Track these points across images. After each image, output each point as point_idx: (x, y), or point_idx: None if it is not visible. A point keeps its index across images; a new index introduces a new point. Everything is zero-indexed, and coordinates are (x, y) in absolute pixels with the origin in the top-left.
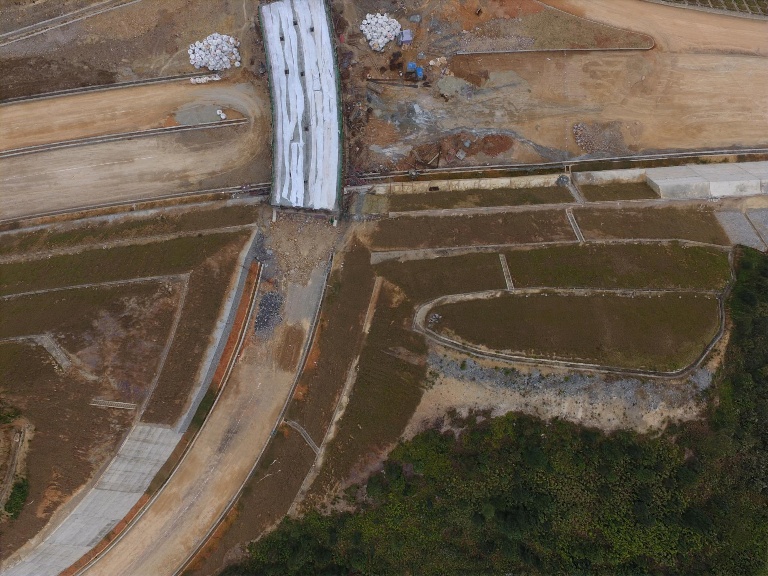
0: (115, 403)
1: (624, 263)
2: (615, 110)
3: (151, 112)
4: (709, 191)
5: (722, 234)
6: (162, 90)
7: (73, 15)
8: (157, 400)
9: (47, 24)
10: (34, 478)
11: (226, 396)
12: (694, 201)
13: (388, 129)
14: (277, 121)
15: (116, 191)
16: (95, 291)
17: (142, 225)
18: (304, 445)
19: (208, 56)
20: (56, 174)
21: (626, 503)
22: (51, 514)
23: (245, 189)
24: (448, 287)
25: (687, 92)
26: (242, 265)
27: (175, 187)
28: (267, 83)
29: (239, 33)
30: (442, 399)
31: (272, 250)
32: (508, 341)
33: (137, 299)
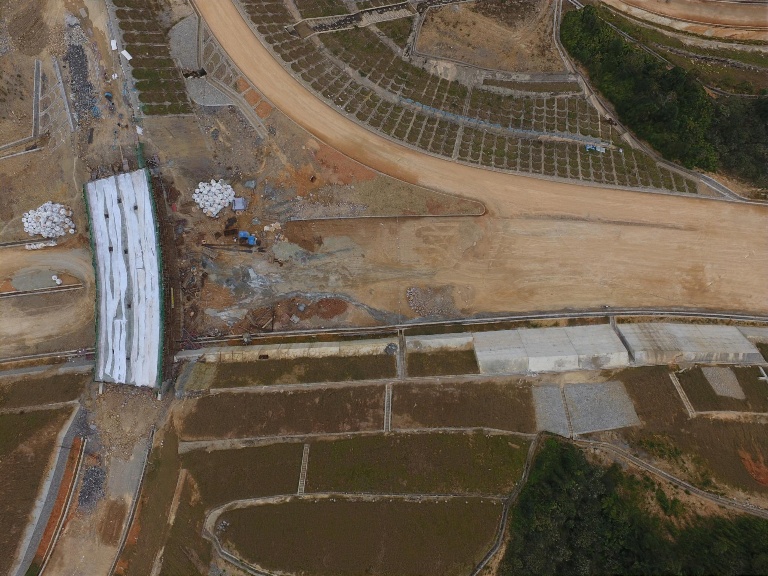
0: None
1: (420, 460)
2: (448, 274)
3: None
4: (528, 366)
5: (531, 418)
6: None
7: None
8: None
9: None
10: None
11: (51, 568)
12: (513, 376)
13: (223, 293)
14: (101, 298)
15: None
16: None
17: None
18: None
19: (38, 228)
20: None
21: None
22: None
23: (80, 353)
24: (241, 490)
25: (519, 257)
26: (60, 445)
27: (12, 350)
28: (92, 260)
29: (72, 203)
30: None
31: (95, 425)
32: (282, 560)
33: None
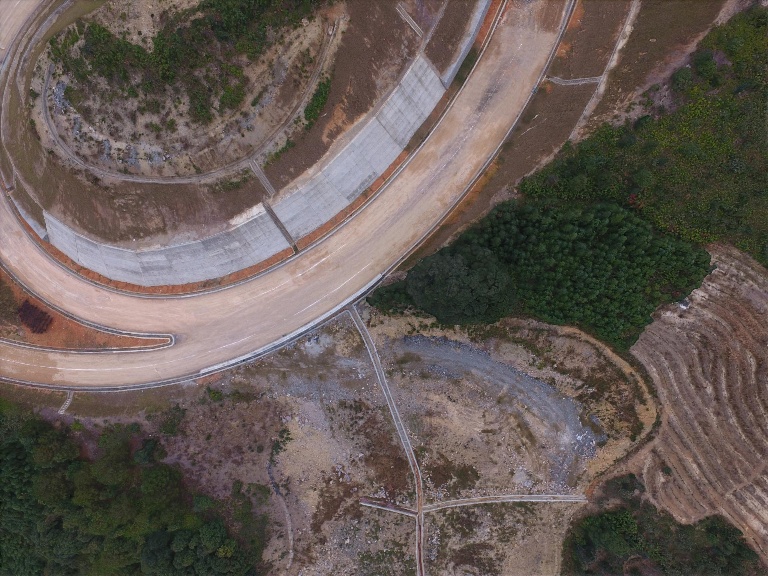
0: (410, 20)
1: None
2: None
3: None
4: None
5: None
6: None
7: None
8: (439, 34)
9: None
10: (335, 82)
11: (487, 57)
12: None
13: None
14: None
15: None
16: None
17: None
18: (576, 87)
19: None
20: None
21: None
22: (331, 142)
23: None
24: None
25: None
26: None
27: None
28: None
29: None
30: None
31: None
32: None
33: None
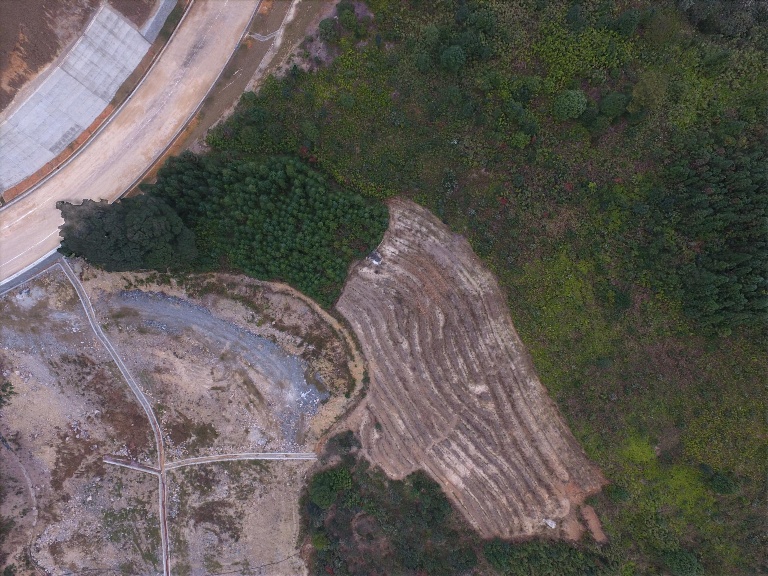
0: None
1: None
2: None
3: None
4: None
5: None
6: None
7: None
8: None
9: None
10: (1, 28)
11: (194, 13)
12: None
13: None
14: None
15: None
16: None
17: None
18: None
19: None
20: None
21: (561, 12)
22: (16, 91)
23: None
24: None
25: None
26: None
27: None
28: None
29: None
30: None
31: None
32: None
33: None
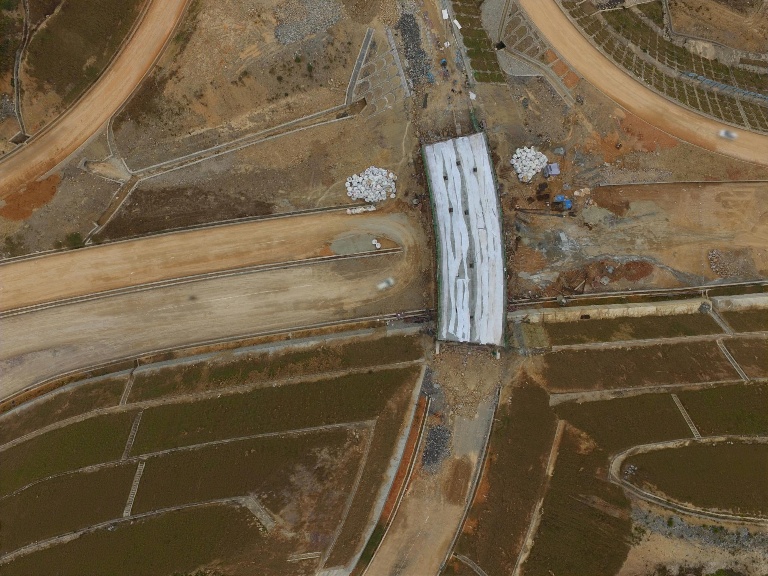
0: (305, 555)
1: None
2: (746, 237)
3: (307, 241)
4: None
5: None
6: (318, 220)
7: (227, 145)
8: (339, 545)
9: (201, 154)
10: None
11: (394, 530)
12: None
13: (536, 256)
14: (442, 258)
15: (271, 319)
16: (283, 440)
17: (305, 357)
18: None
19: (369, 191)
20: (211, 303)
21: None
22: None
23: (400, 316)
24: (637, 436)
25: None
26: (415, 403)
27: (330, 315)
28: (431, 221)
29: (396, 167)
30: (650, 556)
31: (439, 384)
32: (713, 498)
33: (329, 450)
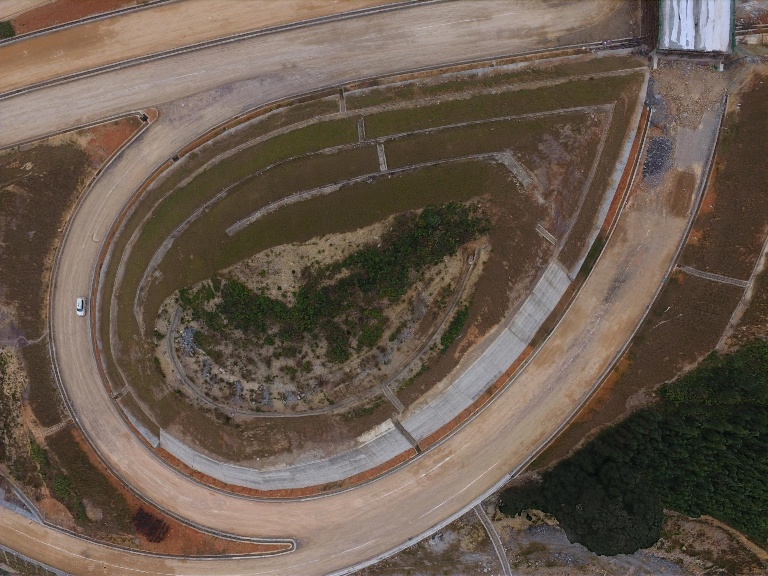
0: (547, 233)
1: None
2: None
3: None
4: None
5: None
6: None
7: None
8: (571, 237)
9: None
10: (473, 307)
11: (613, 244)
12: None
13: None
14: None
15: (474, 49)
16: (521, 122)
17: (516, 76)
18: (715, 285)
19: None
20: (414, 32)
21: None
22: (462, 355)
23: (606, 44)
24: None
25: None
26: (642, 105)
27: (533, 44)
28: None
29: None
30: None
31: (661, 94)
32: None
33: (572, 126)
